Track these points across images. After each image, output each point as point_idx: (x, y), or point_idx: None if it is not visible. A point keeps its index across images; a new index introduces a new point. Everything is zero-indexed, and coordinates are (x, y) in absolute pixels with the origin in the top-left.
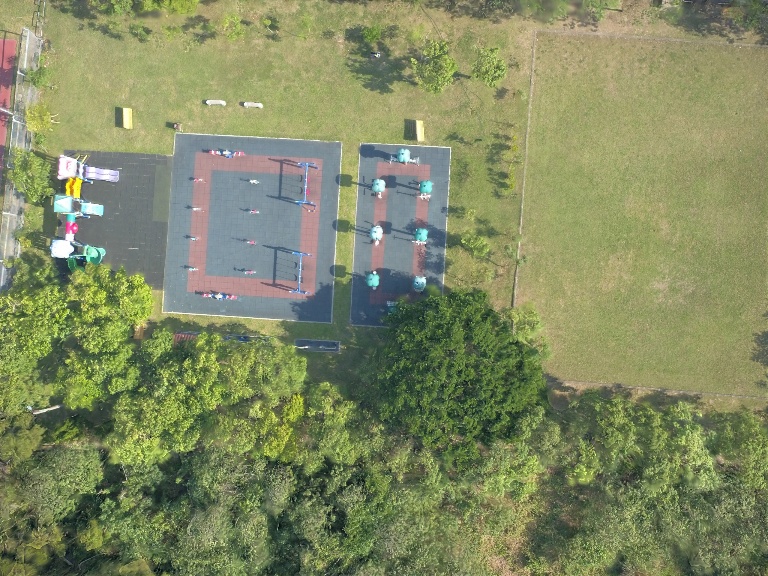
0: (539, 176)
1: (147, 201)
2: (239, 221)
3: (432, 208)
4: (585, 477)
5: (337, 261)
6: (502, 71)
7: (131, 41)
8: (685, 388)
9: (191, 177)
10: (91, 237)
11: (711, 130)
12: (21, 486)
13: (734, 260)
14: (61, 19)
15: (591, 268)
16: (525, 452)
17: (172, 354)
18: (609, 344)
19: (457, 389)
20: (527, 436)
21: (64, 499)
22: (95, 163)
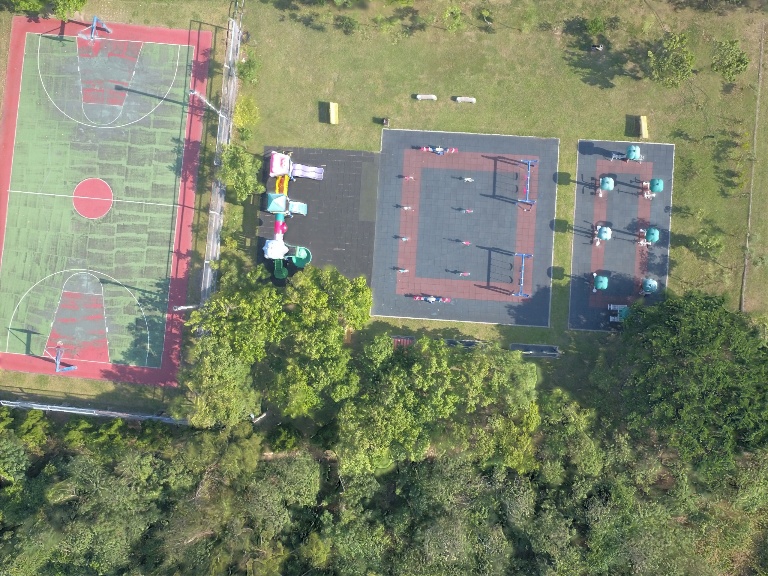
0: (767, 174)
1: (353, 200)
2: (451, 221)
3: (655, 207)
4: None
5: (555, 262)
6: (744, 65)
7: (335, 33)
8: None
9: (400, 175)
10: (294, 237)
11: None
12: (242, 498)
13: None
14: (261, 10)
15: None
16: None
17: (394, 359)
18: None
19: (715, 397)
20: None
21: None
22: (297, 160)
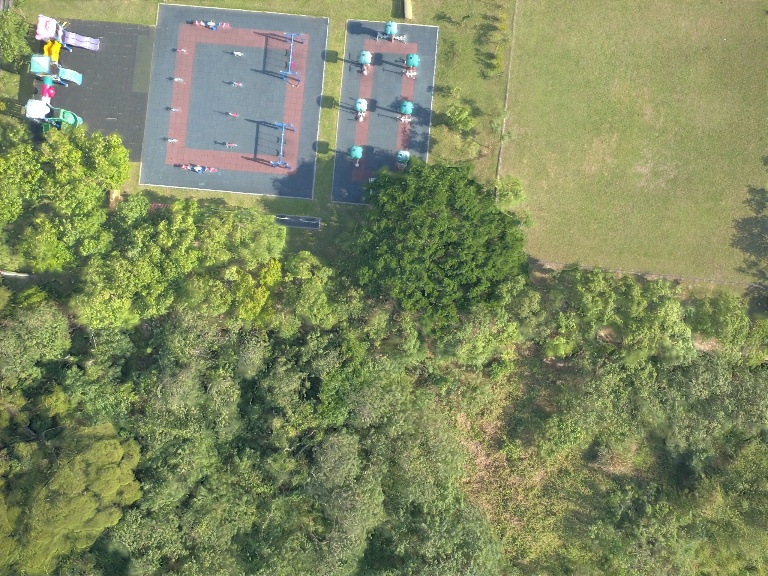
0: (526, 58)
1: (127, 71)
2: (221, 94)
3: (418, 87)
4: (563, 362)
5: (320, 137)
6: None
7: None
8: (665, 273)
9: (174, 48)
10: (68, 106)
11: (696, 18)
12: None
13: (716, 147)
14: None
15: (575, 151)
16: (505, 319)
17: (148, 219)
18: (591, 227)
19: (438, 250)
20: (507, 302)
21: (30, 365)
22: (75, 31)
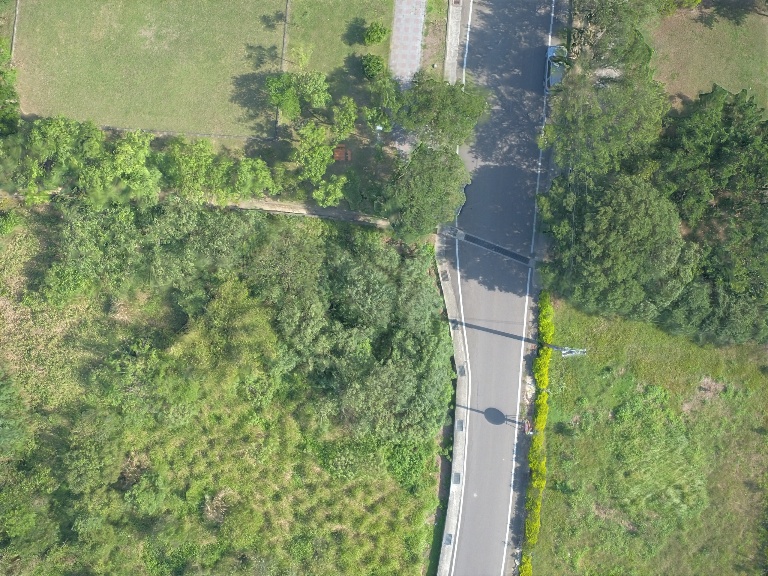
0: None
1: None
2: None
3: None
4: None
5: None
6: None
7: None
8: (168, 129)
9: None
10: None
11: None
12: None
13: (216, 9)
14: None
15: (84, 18)
16: None
17: None
18: (99, 89)
19: None
20: None
21: None
22: None
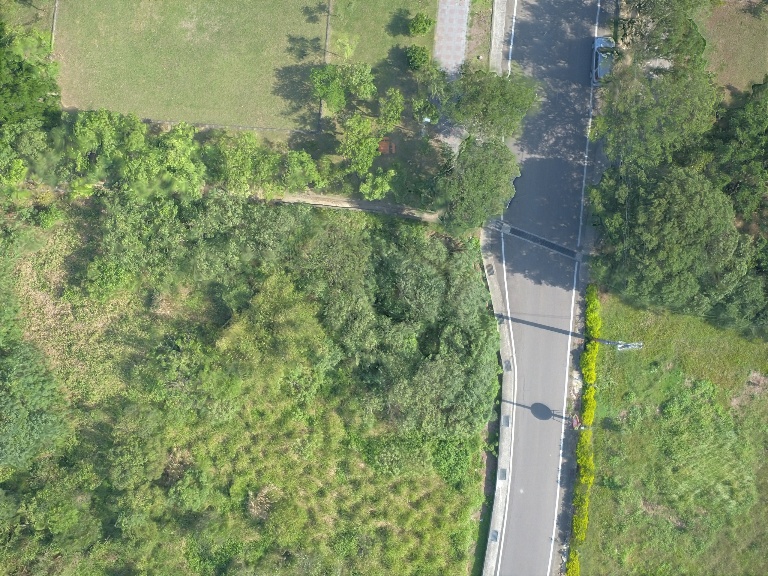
0: None
1: None
2: None
3: None
4: None
5: None
6: None
7: None
8: (210, 122)
9: None
10: None
11: None
12: None
13: None
14: None
15: (124, 10)
16: (12, 157)
17: None
18: (140, 81)
19: None
20: (11, 140)
21: None
22: None
